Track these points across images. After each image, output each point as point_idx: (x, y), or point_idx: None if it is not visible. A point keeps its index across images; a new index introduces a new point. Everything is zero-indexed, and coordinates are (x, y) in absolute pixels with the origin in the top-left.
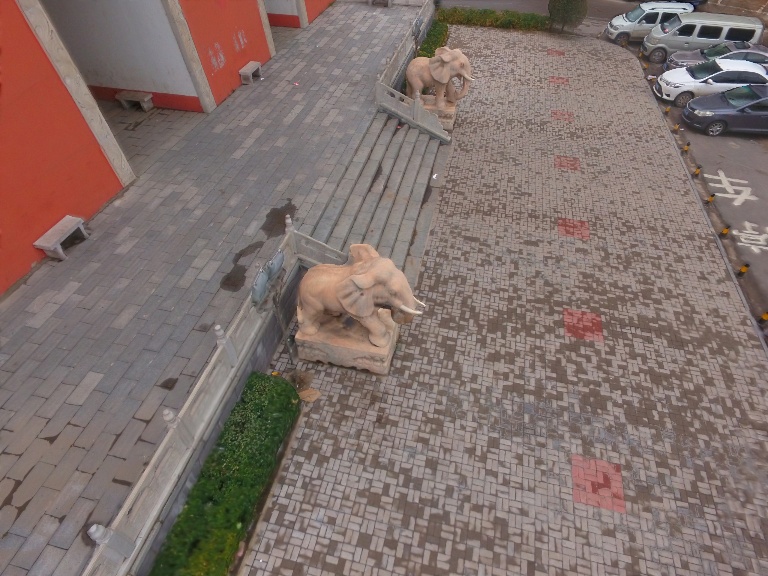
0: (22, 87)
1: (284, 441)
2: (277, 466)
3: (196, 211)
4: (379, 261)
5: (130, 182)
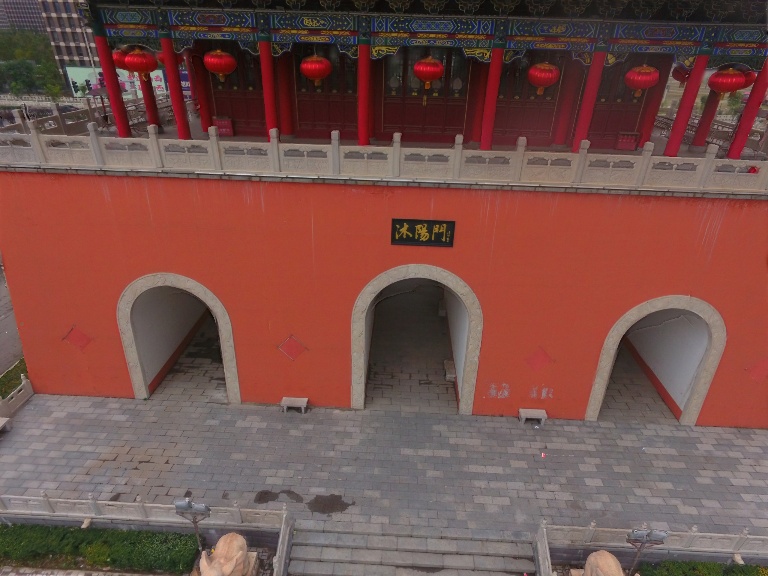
0: (329, 346)
1: (164, 572)
2: (148, 573)
3: (333, 452)
4: (215, 571)
5: (357, 408)
